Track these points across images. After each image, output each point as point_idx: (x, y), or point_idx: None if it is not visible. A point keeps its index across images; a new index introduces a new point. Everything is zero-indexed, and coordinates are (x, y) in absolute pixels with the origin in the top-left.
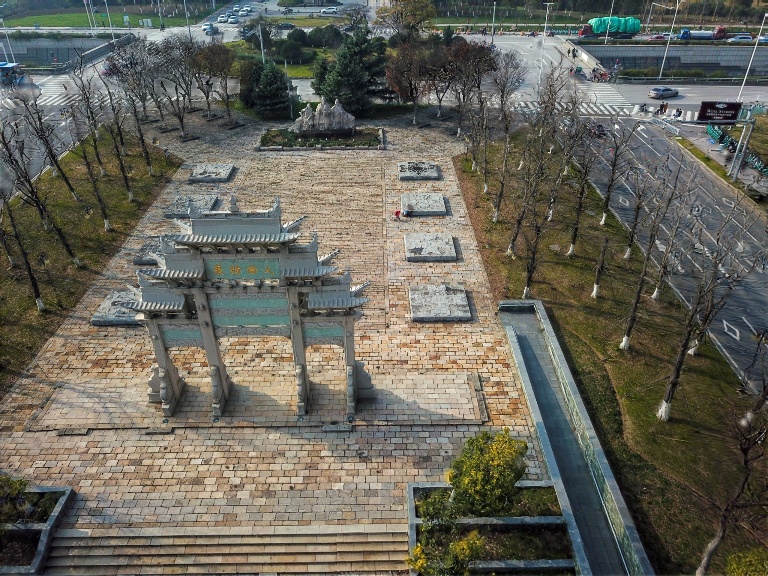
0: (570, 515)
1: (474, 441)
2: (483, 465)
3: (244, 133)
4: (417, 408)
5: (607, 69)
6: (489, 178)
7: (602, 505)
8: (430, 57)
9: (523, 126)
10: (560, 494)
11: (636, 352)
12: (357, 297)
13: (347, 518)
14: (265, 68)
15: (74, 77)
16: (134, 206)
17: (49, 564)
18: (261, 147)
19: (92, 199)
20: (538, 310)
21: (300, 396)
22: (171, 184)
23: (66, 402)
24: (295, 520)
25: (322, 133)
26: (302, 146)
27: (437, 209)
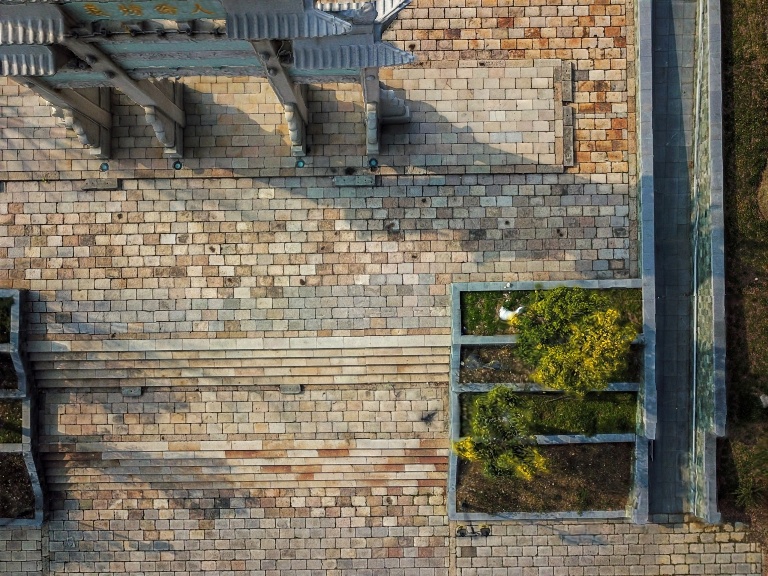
0: (652, 334)
1: (558, 300)
2: (568, 364)
3: None
4: (471, 142)
5: None
6: None
7: (693, 293)
8: None
9: None
10: (647, 303)
11: None
12: (386, 26)
13: (376, 327)
14: None
15: None
16: None
17: (38, 377)
18: None
19: None
20: None
21: (295, 140)
22: None
23: None
24: (313, 330)
25: None
26: None
27: None
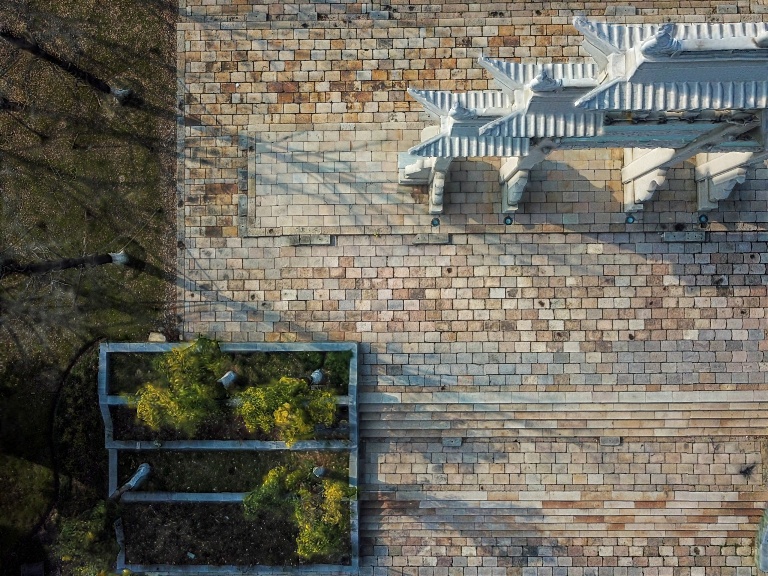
0: None
1: None
2: None
3: None
4: None
5: None
6: None
7: None
8: None
9: None
10: None
11: None
12: None
13: (706, 382)
14: None
15: None
16: None
17: (362, 427)
18: None
19: None
20: None
21: None
22: None
23: (275, 182)
24: (642, 384)
25: None
26: None
27: None
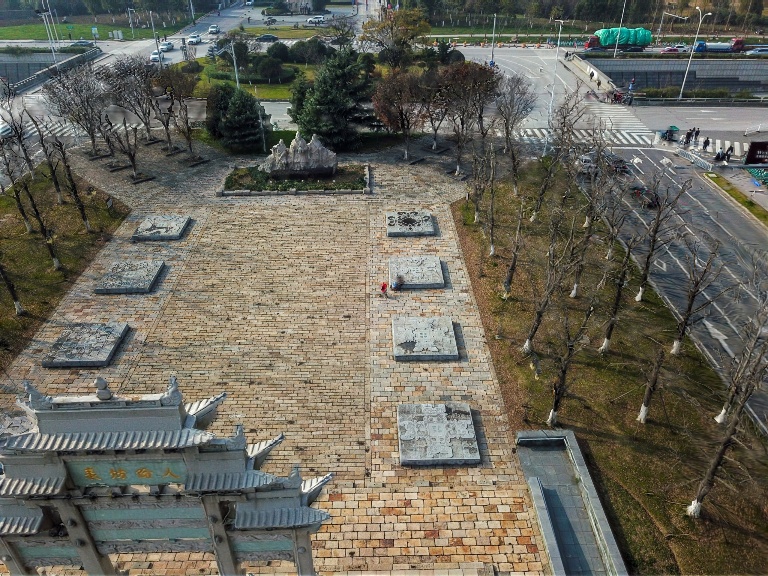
0: None
1: None
2: None
3: (207, 172)
4: None
5: (621, 89)
6: (495, 234)
7: None
8: (424, 76)
9: (532, 161)
10: None
11: (710, 521)
12: (313, 498)
13: None
14: (234, 93)
15: (1, 110)
16: (59, 276)
17: None
18: (225, 191)
19: (9, 266)
20: (571, 449)
21: None
22: (111, 243)
23: None
24: None
25: (297, 174)
26: (273, 190)
27: (433, 281)
